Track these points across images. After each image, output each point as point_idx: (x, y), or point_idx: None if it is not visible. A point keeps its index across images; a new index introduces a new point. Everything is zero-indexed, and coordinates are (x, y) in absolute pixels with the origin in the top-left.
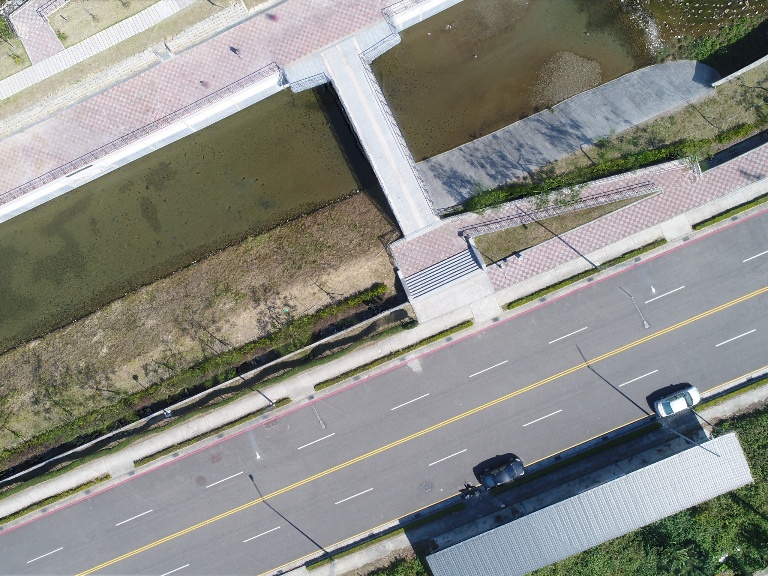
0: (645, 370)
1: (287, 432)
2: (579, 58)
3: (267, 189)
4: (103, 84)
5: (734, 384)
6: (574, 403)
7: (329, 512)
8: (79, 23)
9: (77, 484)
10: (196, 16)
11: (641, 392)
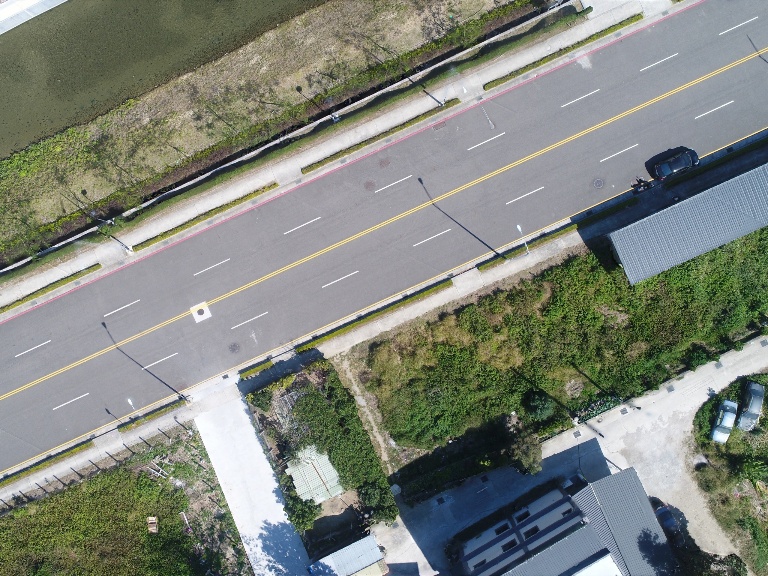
0: None
1: (456, 134)
2: None
3: None
4: None
5: None
6: (746, 93)
7: (500, 212)
8: None
9: (244, 194)
10: None
11: None
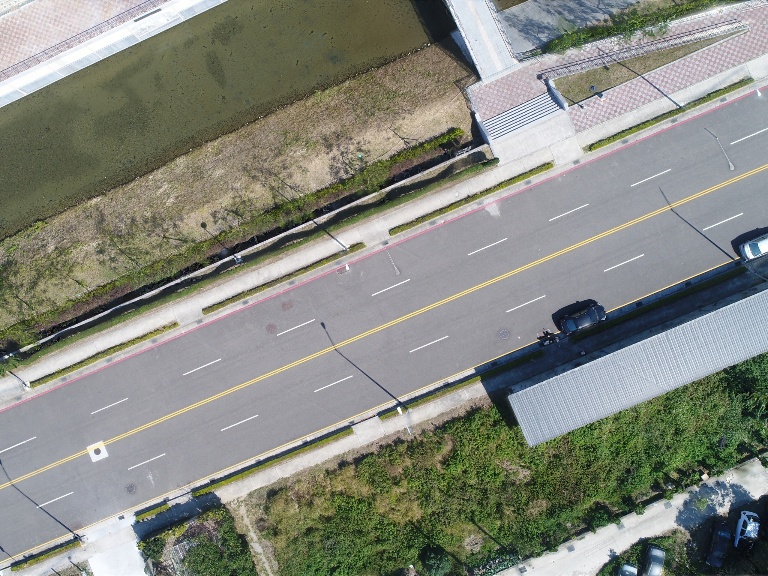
0: (730, 213)
1: (360, 278)
2: None
3: (336, 43)
4: None
5: None
6: (657, 247)
7: (403, 360)
8: None
9: (144, 332)
10: None
11: (726, 236)
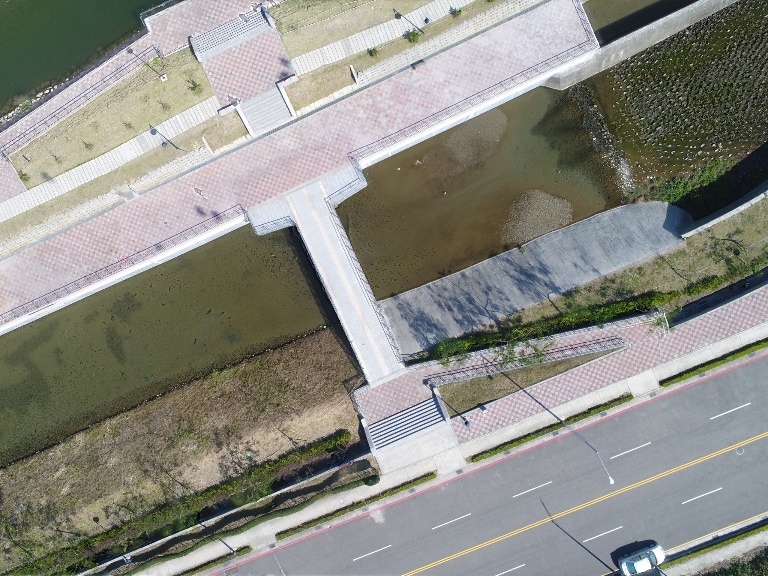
0: (610, 526)
1: None
2: (550, 197)
3: (233, 322)
4: (66, 223)
5: (700, 542)
6: (538, 558)
7: None
8: (41, 164)
9: None
10: (160, 160)
11: (605, 548)
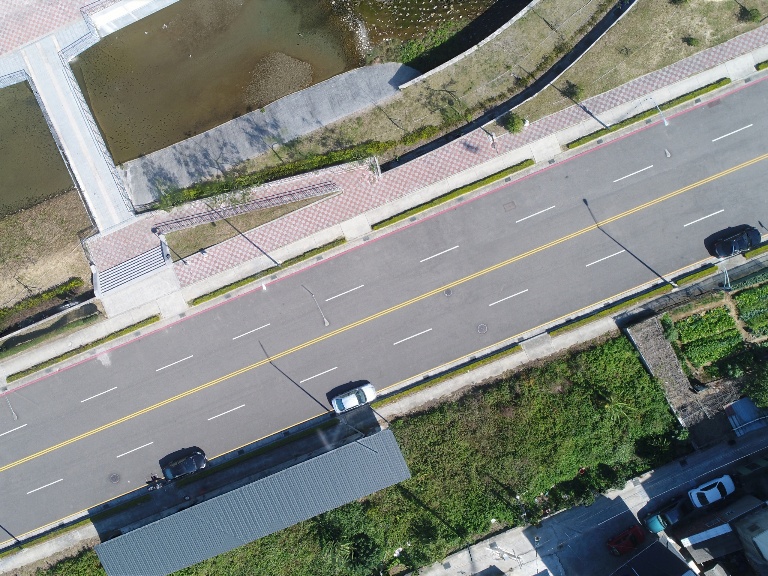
0: (325, 367)
1: None
2: (291, 59)
3: None
4: None
5: (411, 382)
6: (257, 398)
7: (21, 502)
8: None
9: None
10: None
11: (321, 388)
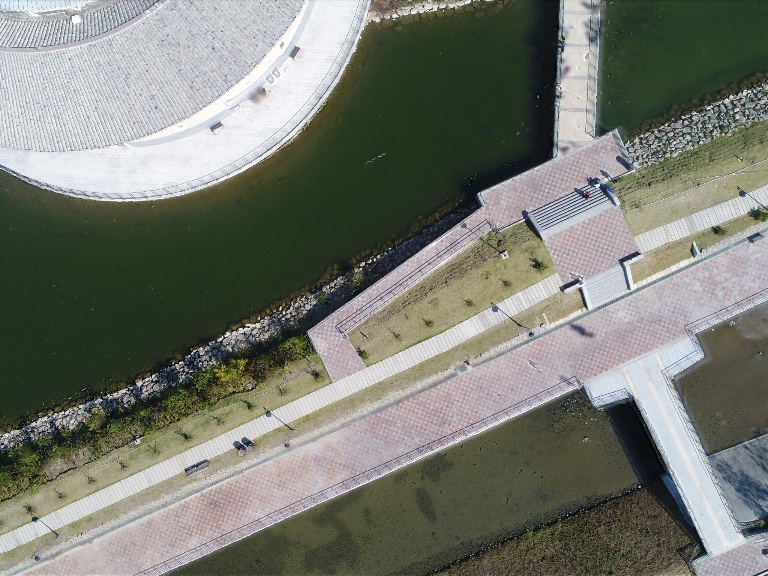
0: None
1: None
2: None
3: (546, 482)
4: (399, 396)
5: None
6: None
7: None
8: (381, 341)
9: None
10: (501, 337)
11: None
